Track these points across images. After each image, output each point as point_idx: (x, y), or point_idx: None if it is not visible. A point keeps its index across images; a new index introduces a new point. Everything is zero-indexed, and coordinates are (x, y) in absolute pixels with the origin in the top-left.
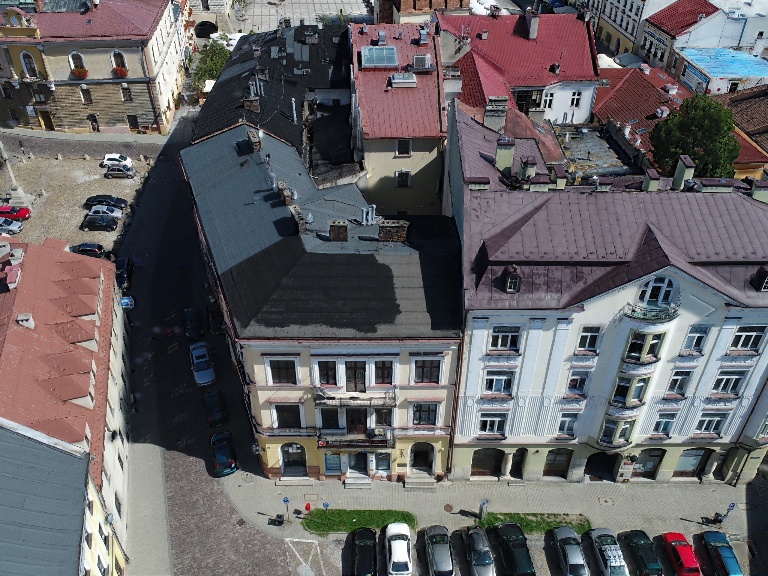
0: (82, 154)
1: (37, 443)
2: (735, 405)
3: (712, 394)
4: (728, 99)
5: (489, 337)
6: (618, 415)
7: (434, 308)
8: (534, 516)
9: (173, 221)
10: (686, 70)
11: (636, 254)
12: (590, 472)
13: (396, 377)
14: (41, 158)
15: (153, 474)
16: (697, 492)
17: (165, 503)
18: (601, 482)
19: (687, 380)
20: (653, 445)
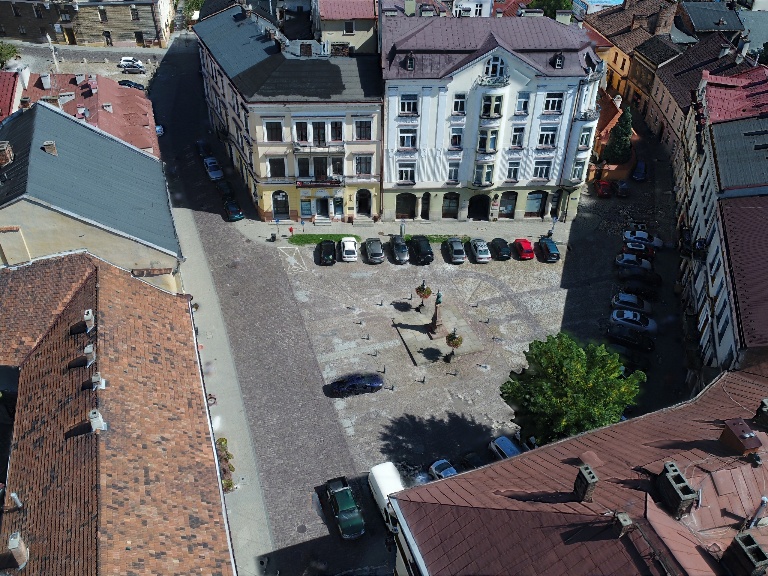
0: (102, 60)
1: (133, 151)
2: (554, 154)
3: (539, 146)
4: (597, 16)
5: (399, 102)
6: (482, 160)
7: (366, 86)
8: (436, 236)
9: (180, 98)
10: (573, 2)
11: (482, 46)
12: (473, 217)
13: (344, 134)
14: (70, 62)
15: (188, 221)
16: (540, 225)
17: (198, 233)
18: (480, 221)
19: (523, 136)
20: (509, 188)
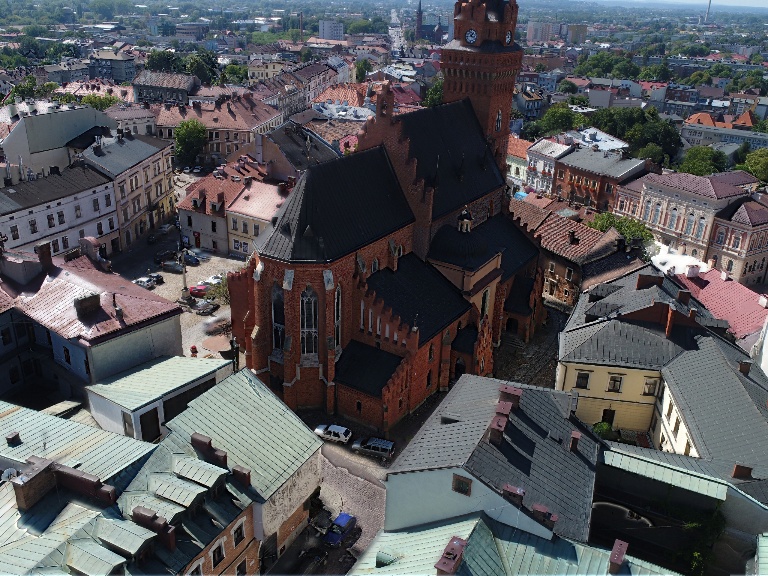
0: None
1: None
2: None
3: None
4: None
5: None
6: None
7: None
8: None
9: None
10: None
11: None
12: None
13: None
14: None
15: None
16: None
17: None
18: None
19: None
20: None
